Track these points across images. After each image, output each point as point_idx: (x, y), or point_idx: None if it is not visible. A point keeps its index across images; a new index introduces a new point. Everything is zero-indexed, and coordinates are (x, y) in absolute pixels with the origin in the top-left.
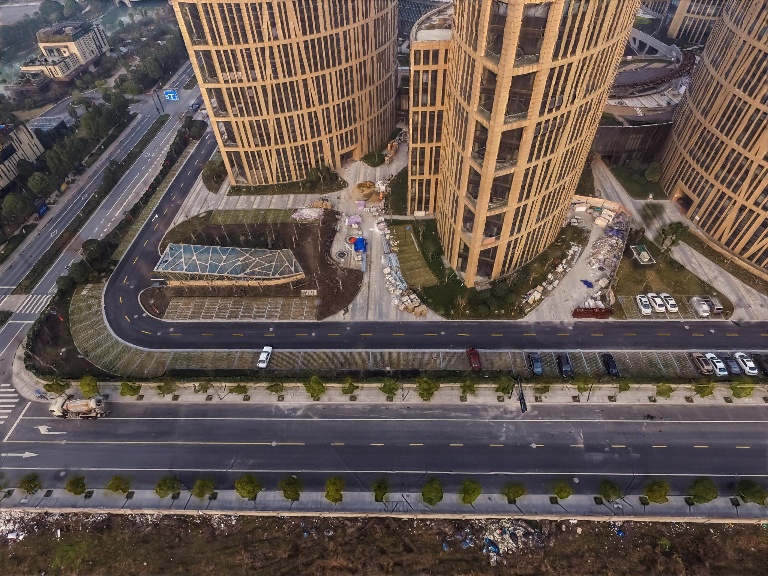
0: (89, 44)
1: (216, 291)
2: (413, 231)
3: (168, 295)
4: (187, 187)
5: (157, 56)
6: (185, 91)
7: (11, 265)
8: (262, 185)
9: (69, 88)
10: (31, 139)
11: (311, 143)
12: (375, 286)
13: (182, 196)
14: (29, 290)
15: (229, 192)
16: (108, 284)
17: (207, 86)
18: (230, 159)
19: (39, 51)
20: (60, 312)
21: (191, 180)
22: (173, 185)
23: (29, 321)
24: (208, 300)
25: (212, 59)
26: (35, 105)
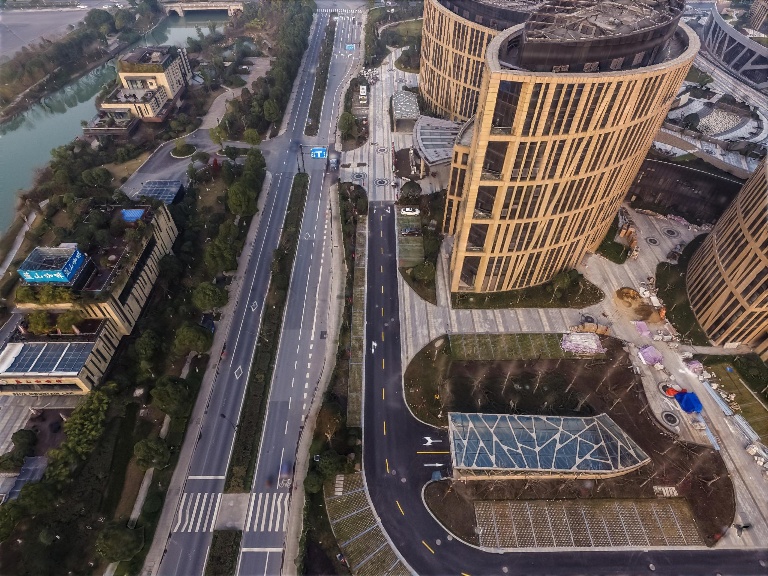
0: (176, 73)
1: (534, 490)
2: (740, 375)
3: (467, 498)
4: (391, 293)
5: (270, 93)
6: (309, 138)
7: (200, 433)
8: (492, 292)
9: (159, 130)
10: (168, 222)
11: (569, 243)
12: (750, 478)
13: (392, 309)
14: (249, 485)
15: (454, 303)
16: (366, 475)
17: (482, 183)
18: (424, 247)
19: (118, 82)
20: (320, 534)
21: (391, 281)
22: (371, 290)
23: (272, 548)
24: (529, 507)
25: (505, 151)
26: (129, 156)
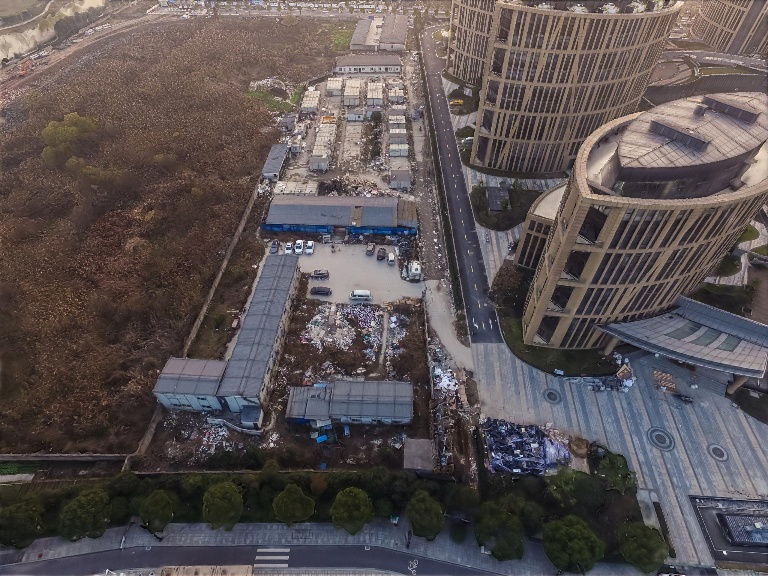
0: None
1: None
2: None
3: None
4: None
5: None
6: None
7: None
8: None
9: None
10: None
11: None
12: None
13: None
14: None
15: None
16: None
17: None
18: None
19: None
20: None
21: None
22: None
23: None
24: None
25: None
26: None
